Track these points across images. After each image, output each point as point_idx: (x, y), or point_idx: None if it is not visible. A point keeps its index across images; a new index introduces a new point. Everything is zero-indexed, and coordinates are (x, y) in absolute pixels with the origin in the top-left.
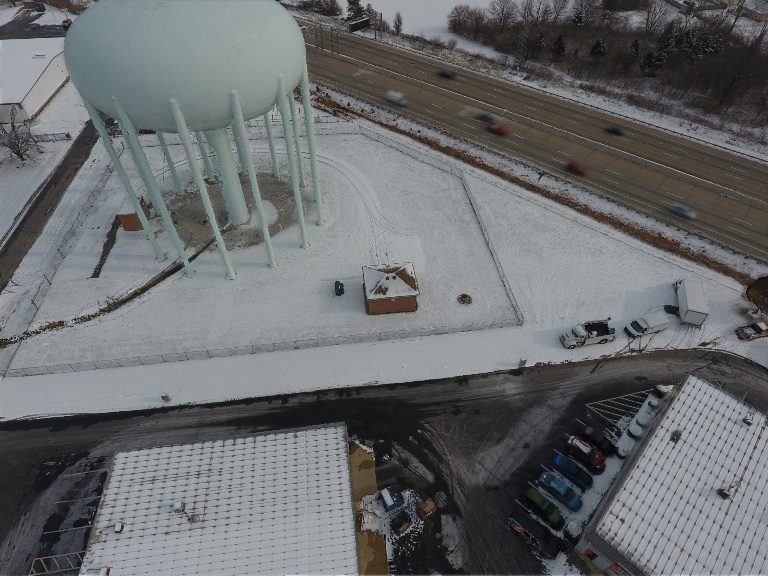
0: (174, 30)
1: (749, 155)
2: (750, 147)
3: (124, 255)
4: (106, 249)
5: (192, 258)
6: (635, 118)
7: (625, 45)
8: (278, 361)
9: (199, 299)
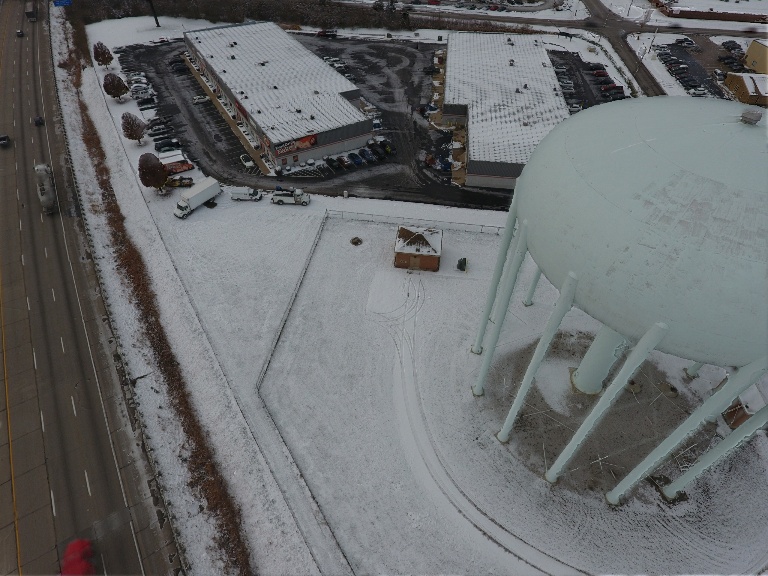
0: None
1: None
2: None
3: None
4: None
5: None
6: None
7: None
8: None
9: None
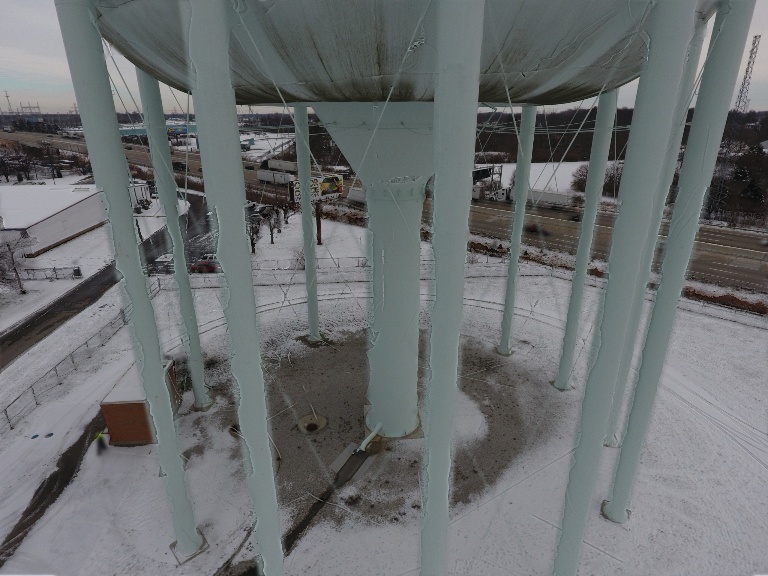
0: None
1: None
2: None
3: (80, 527)
4: (38, 502)
5: None
6: None
7: None
8: None
9: None
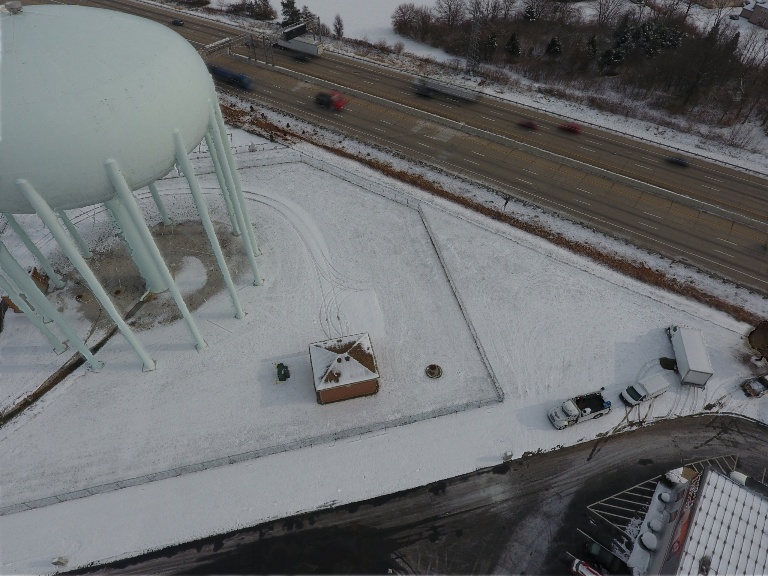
0: (12, 86)
1: (722, 161)
2: (721, 151)
3: (12, 348)
4: None
5: (100, 344)
6: (600, 125)
7: (582, 43)
8: (209, 485)
9: (108, 403)
